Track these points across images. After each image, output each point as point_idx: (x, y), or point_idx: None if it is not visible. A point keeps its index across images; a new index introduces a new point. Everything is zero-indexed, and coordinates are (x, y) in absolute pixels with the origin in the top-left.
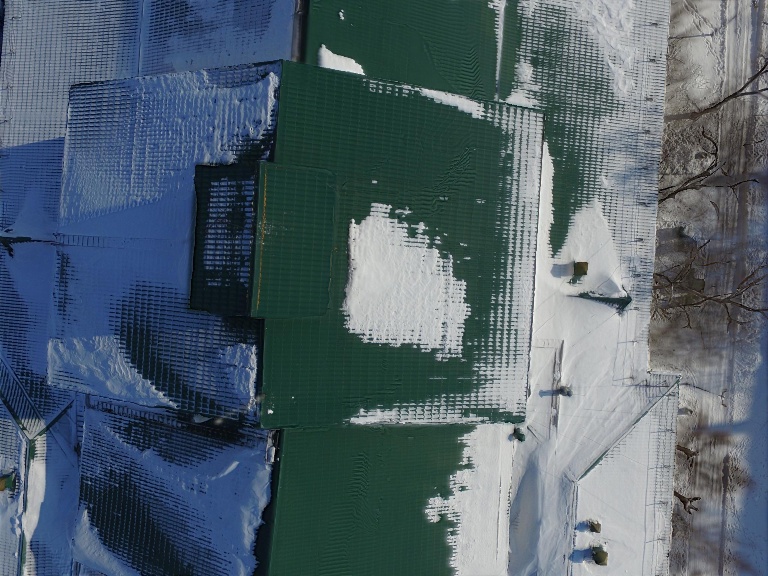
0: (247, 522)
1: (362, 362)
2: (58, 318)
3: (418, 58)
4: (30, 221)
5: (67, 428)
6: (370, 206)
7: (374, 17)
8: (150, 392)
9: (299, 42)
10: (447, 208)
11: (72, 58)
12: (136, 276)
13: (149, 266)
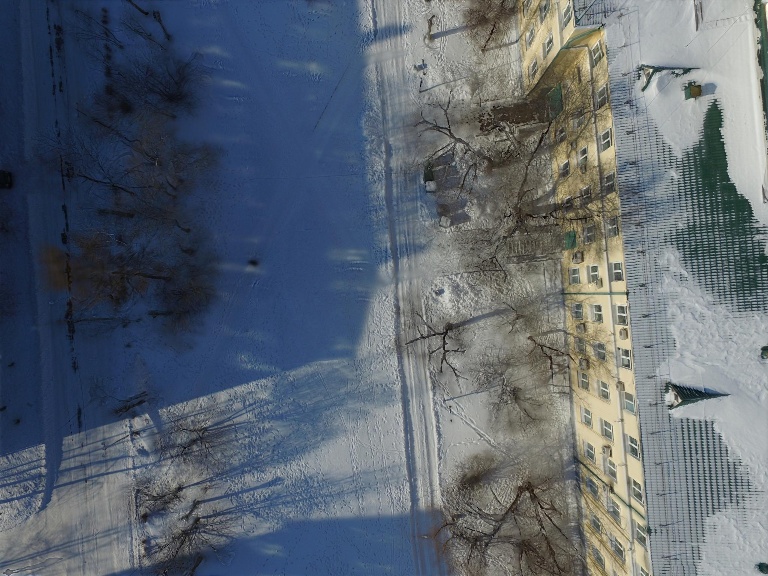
0: None
1: None
2: None
3: None
4: None
5: None
6: None
7: None
8: None
9: None
10: None
11: None
12: None
13: None
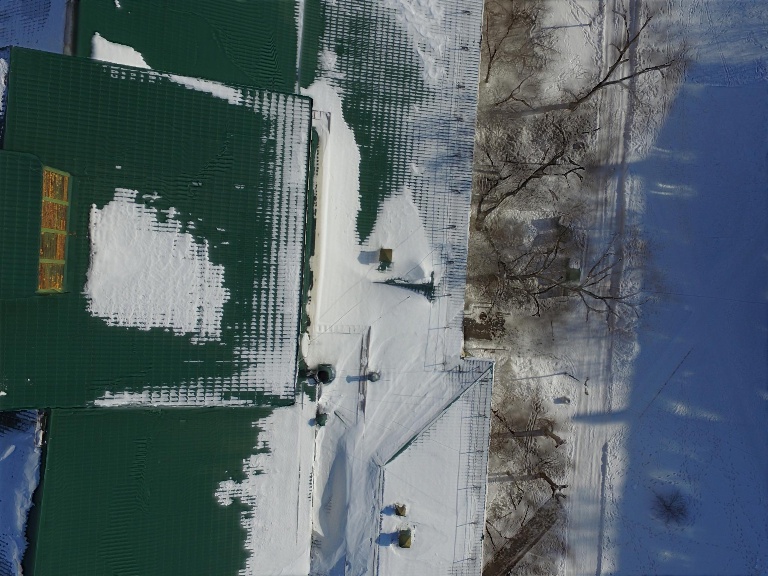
0: (20, 504)
1: (113, 345)
2: None
3: (208, 46)
4: None
5: None
6: (114, 191)
7: (159, 5)
8: None
9: (72, 30)
10: (201, 193)
11: None
12: None
13: None
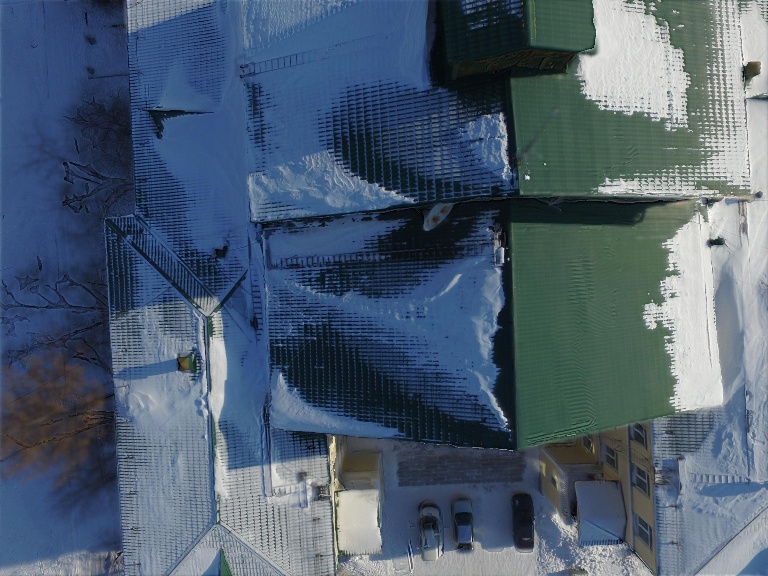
0: (481, 331)
1: (596, 135)
2: (256, 151)
3: None
4: (178, 97)
5: (242, 302)
6: None
7: None
8: (380, 194)
9: None
10: None
11: None
12: (347, 82)
13: (362, 67)
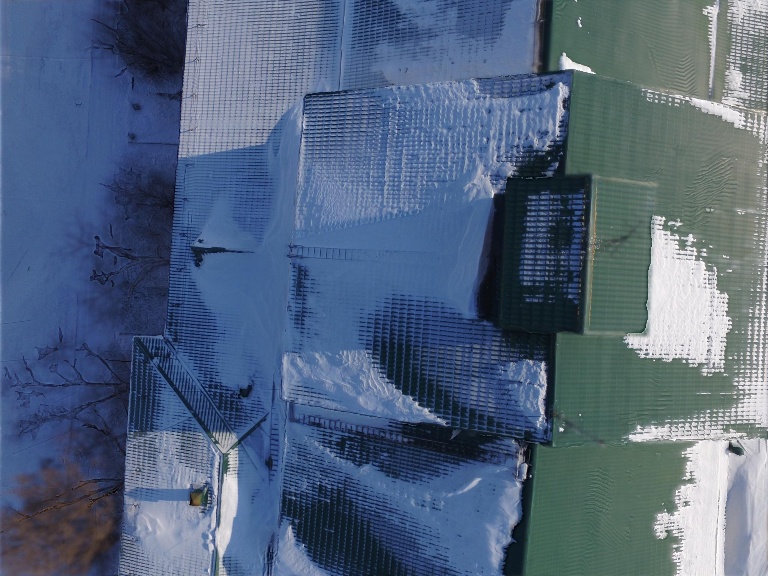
0: (494, 540)
1: (633, 377)
2: (295, 332)
3: (642, 66)
4: (220, 231)
5: (259, 441)
6: None
7: None
8: (413, 408)
9: (540, 50)
10: (712, 220)
11: (263, 66)
12: (393, 289)
13: (410, 279)
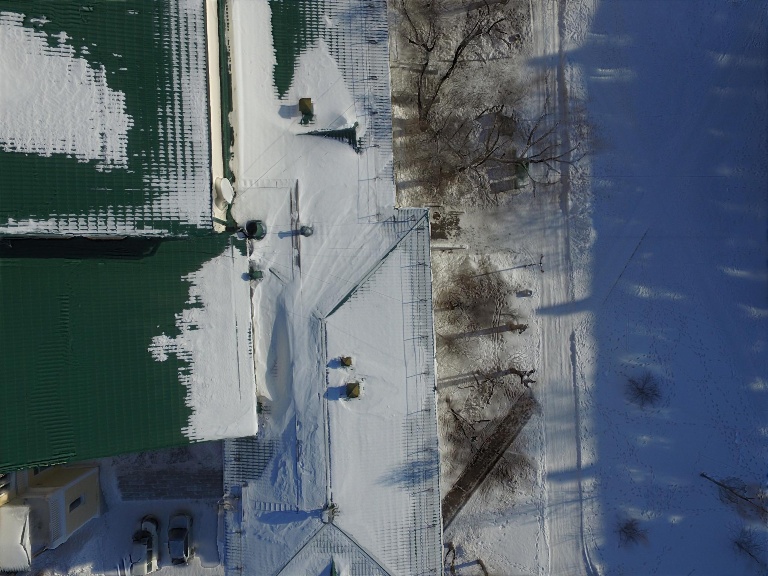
0: None
1: (14, 176)
2: None
3: None
4: None
5: None
6: None
7: None
8: None
9: None
10: (93, 18)
11: None
12: None
13: None
